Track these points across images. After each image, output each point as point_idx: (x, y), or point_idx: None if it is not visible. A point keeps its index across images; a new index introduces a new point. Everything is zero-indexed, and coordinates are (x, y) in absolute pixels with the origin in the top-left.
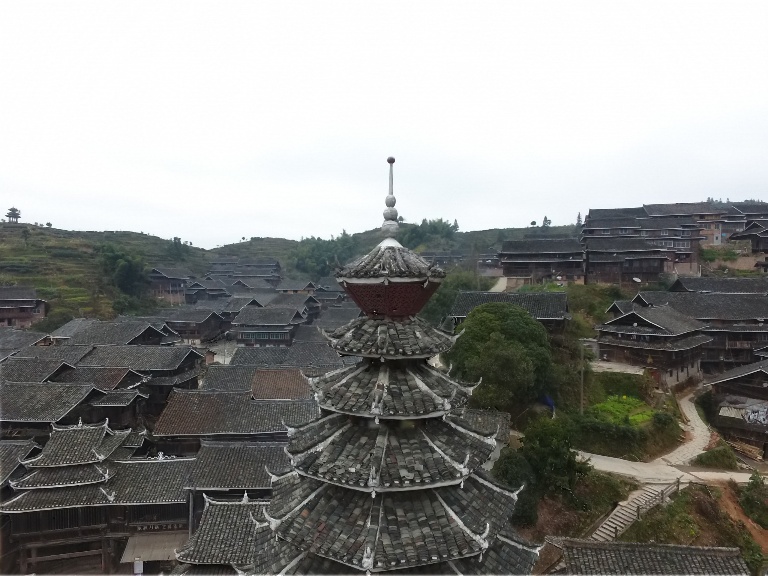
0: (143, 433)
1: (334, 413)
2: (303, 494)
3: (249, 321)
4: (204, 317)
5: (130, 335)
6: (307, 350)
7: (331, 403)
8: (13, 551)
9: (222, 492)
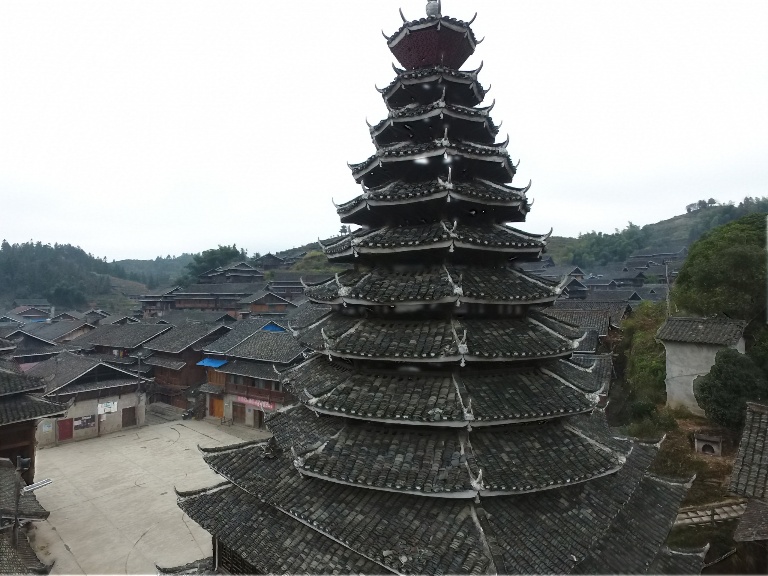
0: None
1: None
2: None
3: None
4: None
5: None
6: None
7: None
8: None
9: None
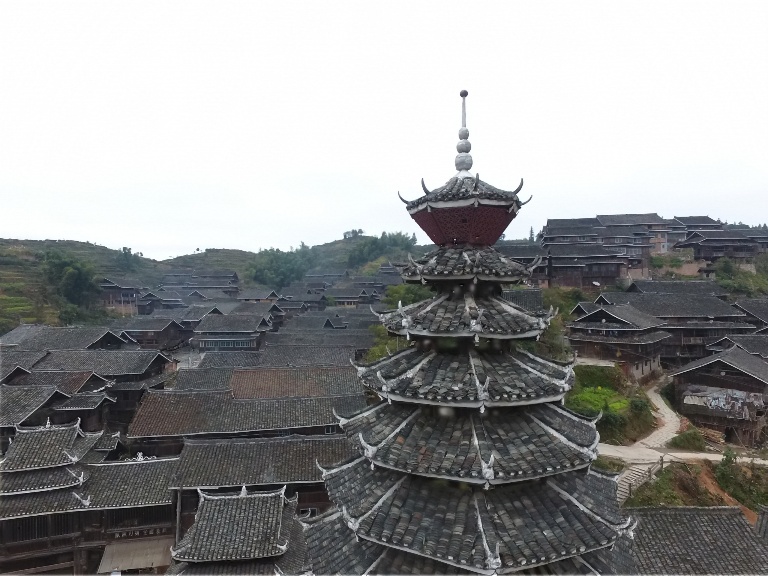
0: (116, 435)
1: (407, 350)
2: (395, 422)
3: (213, 329)
4: (163, 325)
5: (87, 341)
6: (281, 353)
7: (422, 327)
8: None
9: (211, 491)
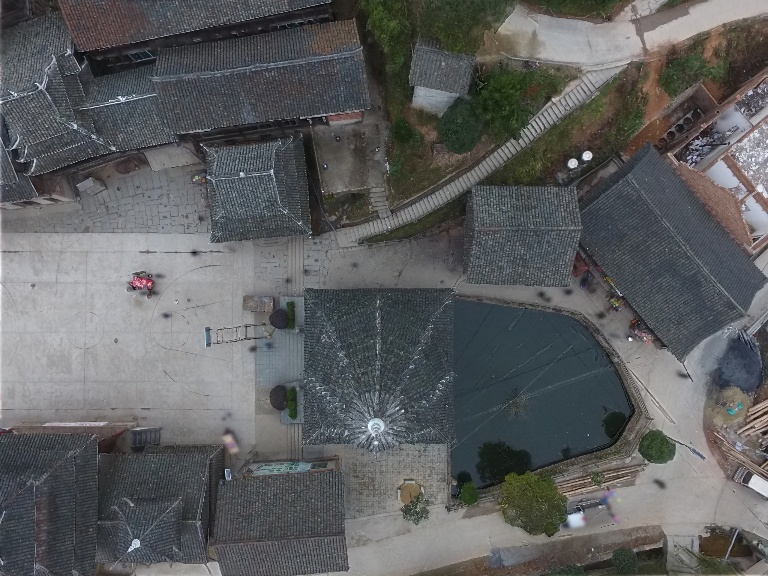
0: (68, 54)
1: None
2: None
3: None
4: None
5: None
6: None
7: None
8: (64, 177)
9: None
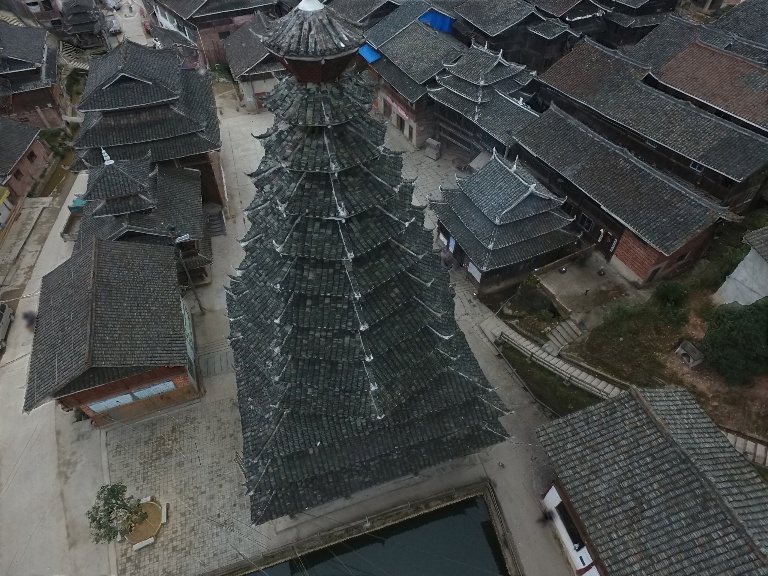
0: (533, 74)
1: None
2: None
3: None
4: None
5: None
6: None
7: None
8: (433, 123)
9: (532, 155)
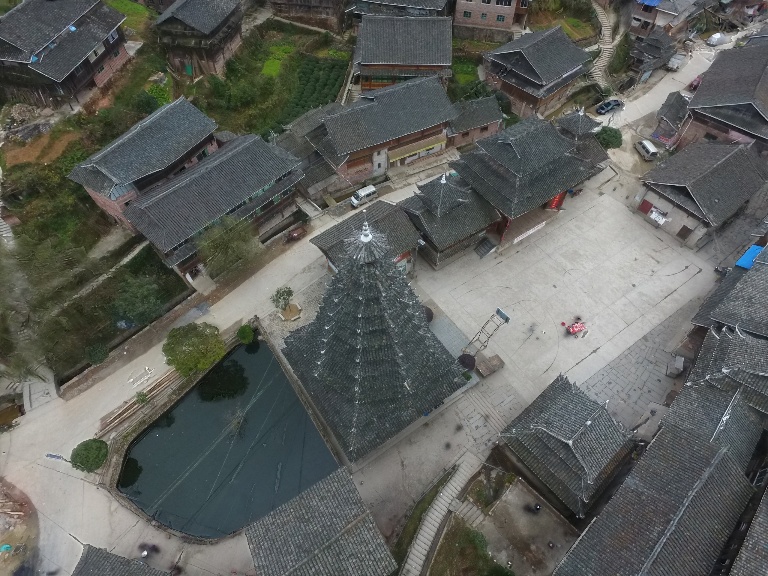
0: None
1: None
2: None
3: None
4: None
5: None
6: None
7: None
8: None
9: None
